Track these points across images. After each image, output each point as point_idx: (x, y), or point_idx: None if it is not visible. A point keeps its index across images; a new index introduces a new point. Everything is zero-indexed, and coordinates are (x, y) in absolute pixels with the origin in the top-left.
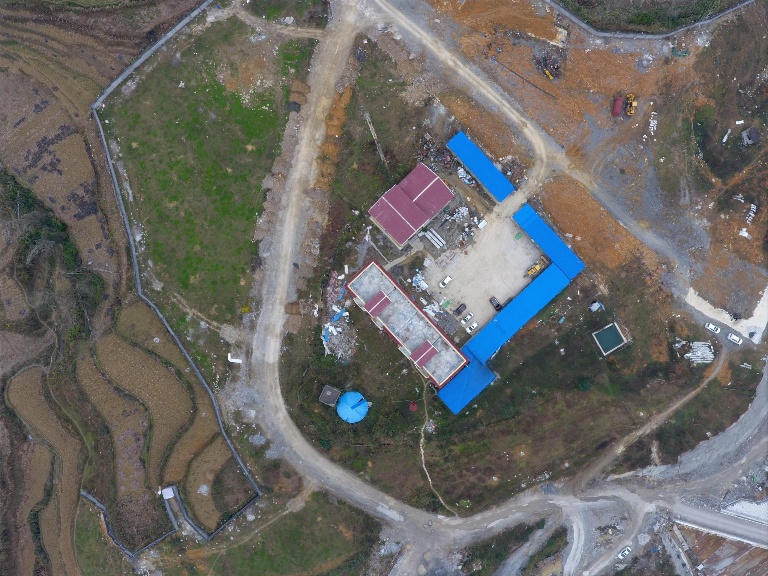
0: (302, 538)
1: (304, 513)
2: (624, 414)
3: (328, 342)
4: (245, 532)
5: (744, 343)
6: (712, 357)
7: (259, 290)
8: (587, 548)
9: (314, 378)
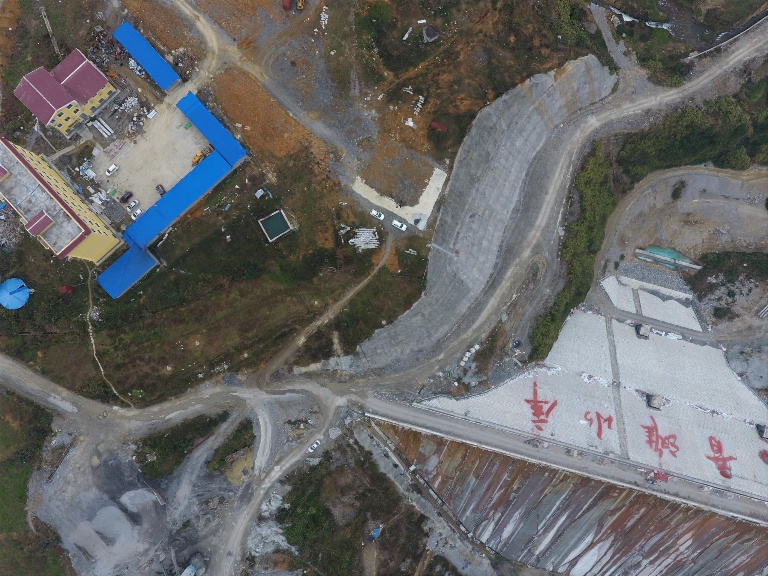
0: None
1: None
2: (300, 303)
3: None
4: None
5: (410, 230)
6: (376, 243)
7: None
8: (276, 442)
9: None
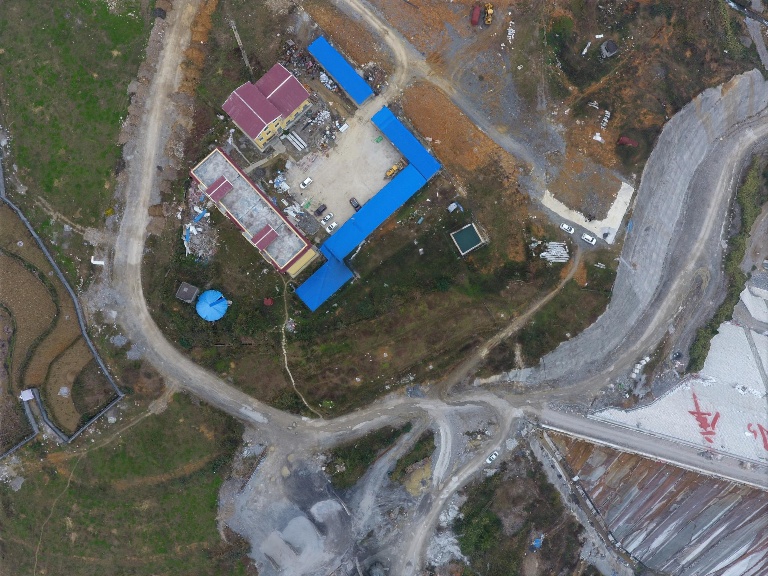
0: (164, 440)
1: (166, 415)
2: (486, 316)
3: (189, 242)
4: (106, 434)
5: (598, 244)
6: (566, 256)
7: (122, 192)
8: (455, 453)
9: (174, 277)
